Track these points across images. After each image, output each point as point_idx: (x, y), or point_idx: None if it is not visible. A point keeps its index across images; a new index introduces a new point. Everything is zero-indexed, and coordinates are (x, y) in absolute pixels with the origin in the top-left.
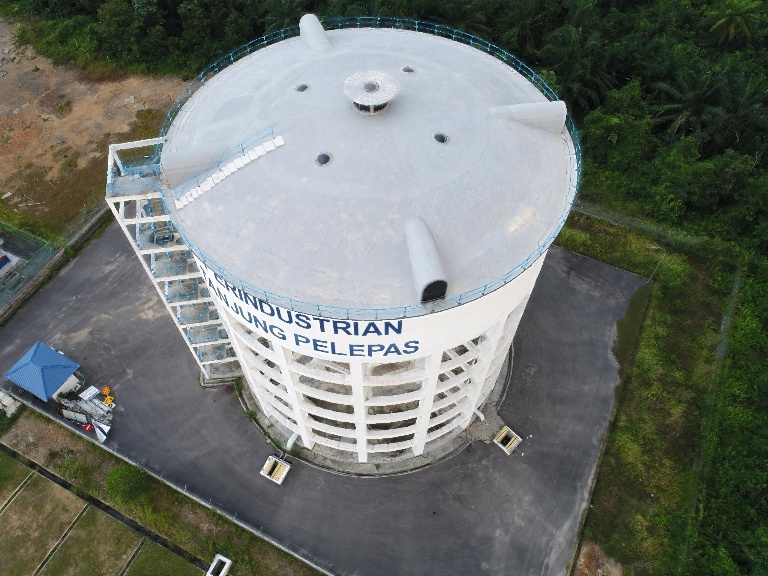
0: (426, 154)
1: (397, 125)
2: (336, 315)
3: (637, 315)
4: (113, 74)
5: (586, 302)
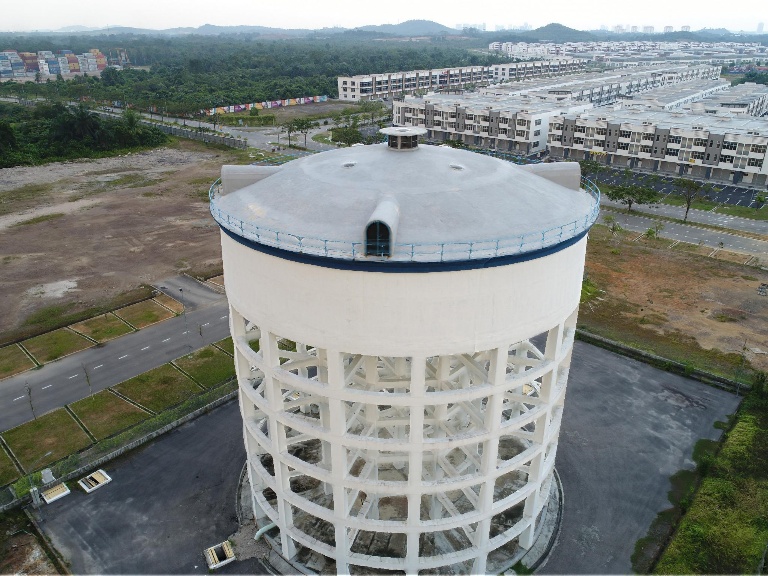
0: None
1: None
2: None
3: None
4: None
5: None
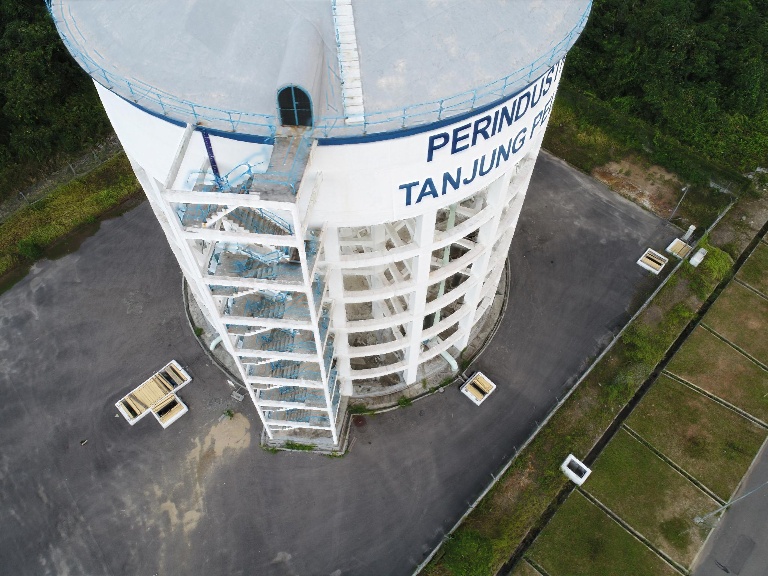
0: None
1: None
2: None
3: None
4: None
5: None
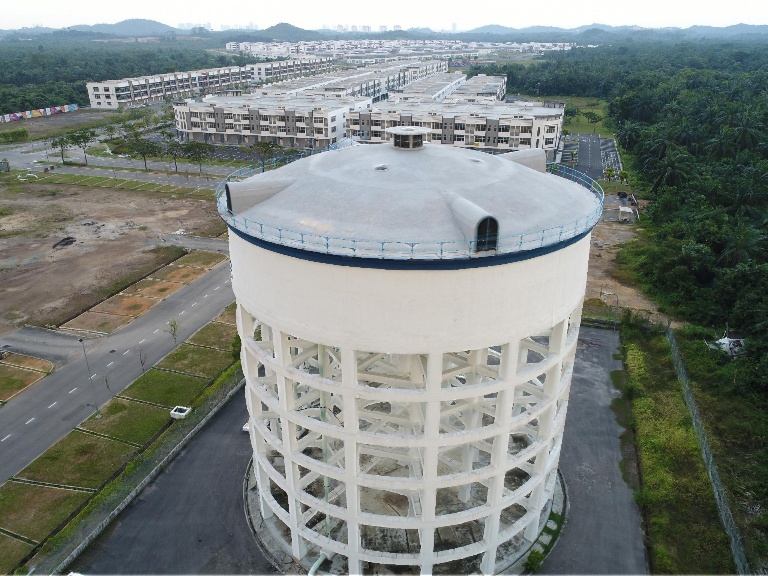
0: (360, 166)
1: (386, 154)
2: None
3: None
4: (627, 280)
5: None
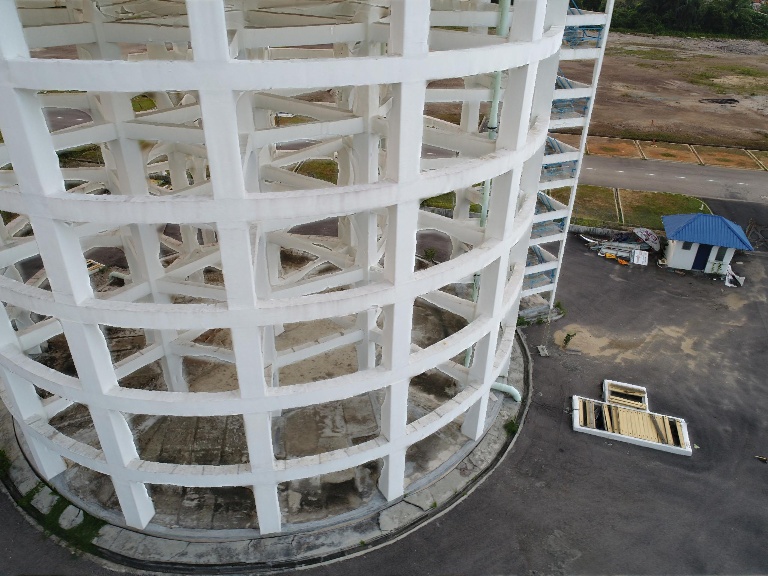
0: None
1: None
2: None
3: None
4: None
5: None
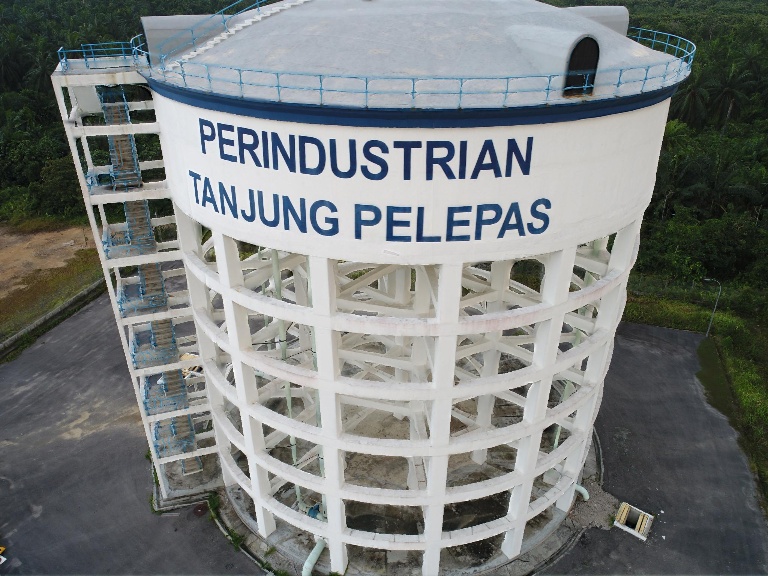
0: None
1: None
2: (440, 107)
3: (715, 366)
4: (51, 226)
5: (649, 360)
